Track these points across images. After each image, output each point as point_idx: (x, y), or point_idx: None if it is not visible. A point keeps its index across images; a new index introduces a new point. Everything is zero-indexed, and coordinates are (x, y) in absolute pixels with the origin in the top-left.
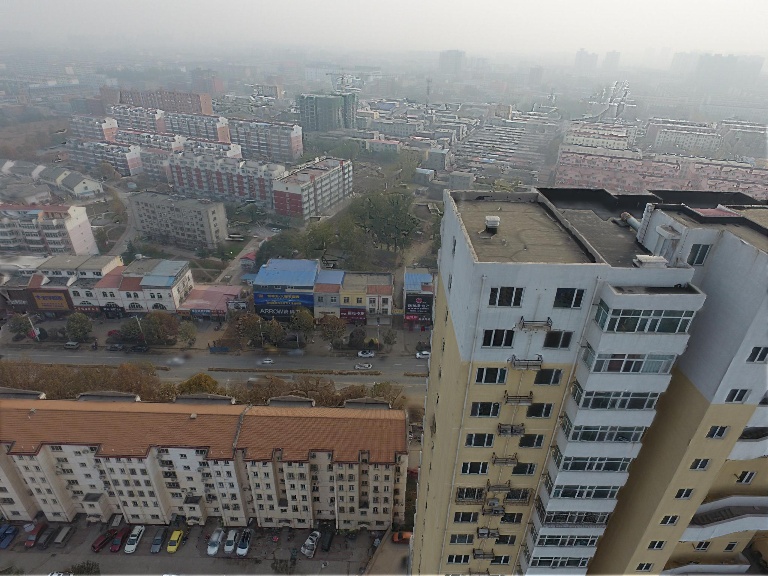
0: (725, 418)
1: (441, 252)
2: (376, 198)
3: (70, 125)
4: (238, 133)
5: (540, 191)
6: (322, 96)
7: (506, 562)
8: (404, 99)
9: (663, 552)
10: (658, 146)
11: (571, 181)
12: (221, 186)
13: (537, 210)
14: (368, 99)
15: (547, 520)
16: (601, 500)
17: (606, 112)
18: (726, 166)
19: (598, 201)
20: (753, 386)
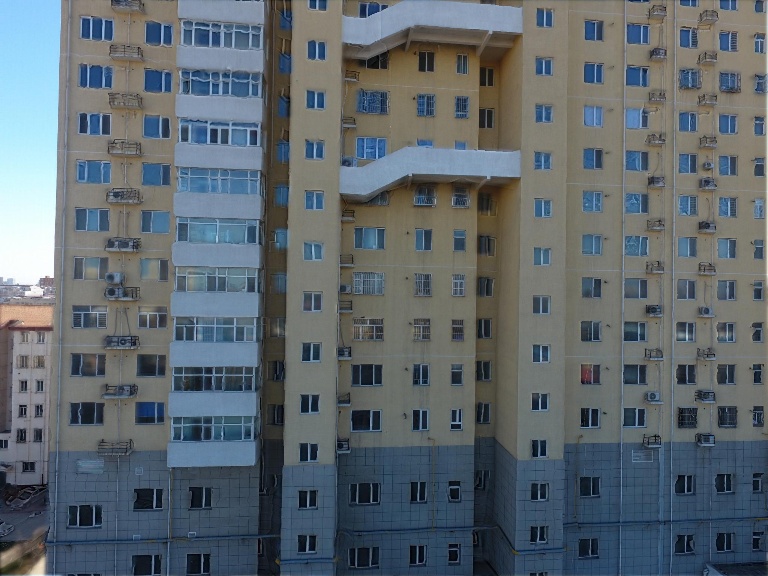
0: None
1: None
2: None
3: None
4: None
5: None
6: None
7: (169, 43)
8: None
9: None
10: None
11: None
12: None
13: None
14: None
15: None
16: None
17: None
18: None
19: None
20: None
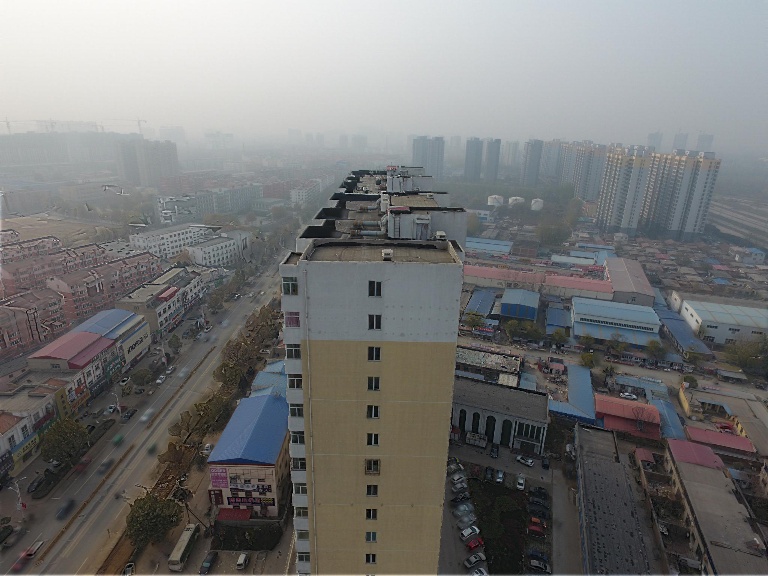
0: None
1: (308, 321)
2: None
3: None
4: None
5: None
6: None
7: None
8: None
9: None
10: None
11: None
12: None
13: (338, 248)
14: None
15: None
16: None
17: None
18: None
19: (310, 235)
20: None
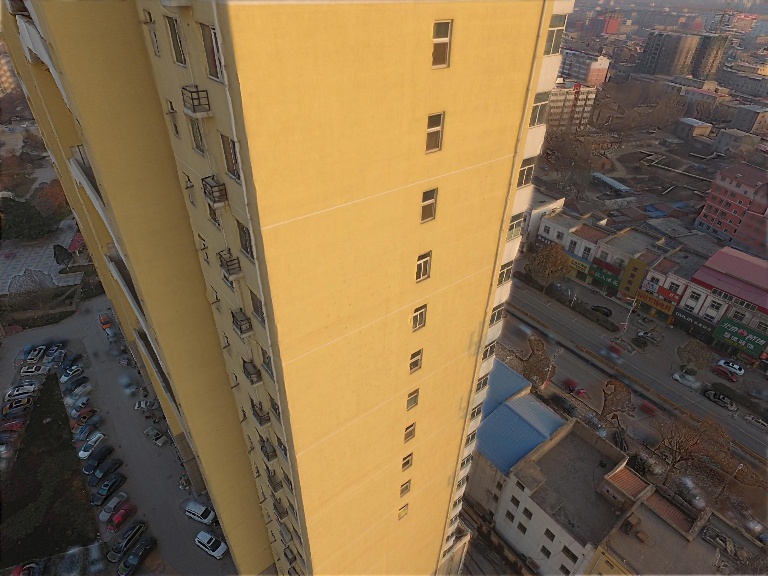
0: None
1: None
2: None
3: None
4: None
5: None
6: (676, 34)
7: None
8: None
9: None
10: None
11: None
12: None
13: None
14: None
15: None
16: None
17: None
18: None
19: None
20: None
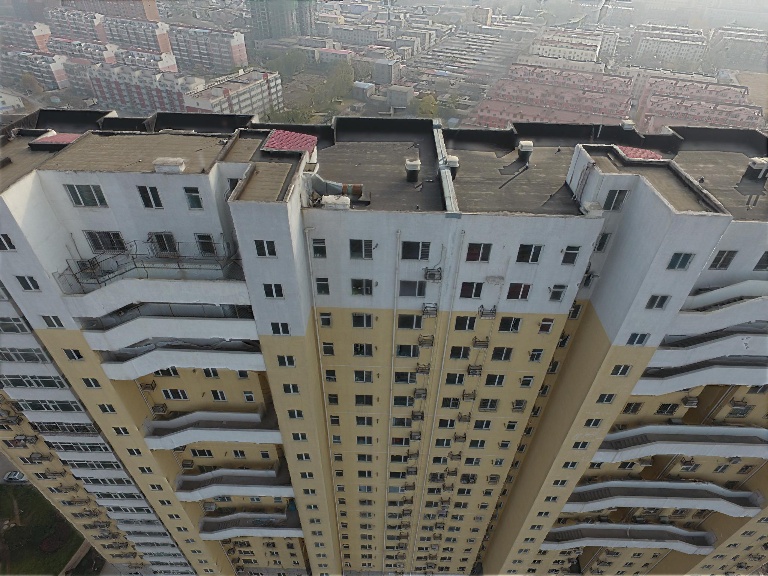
0: (63, 342)
1: None
2: (276, 115)
3: (1, 31)
4: (178, 41)
5: (48, 113)
6: None
7: None
8: (381, 1)
9: (145, 458)
10: (638, 57)
11: (509, 97)
12: (142, 101)
13: None
14: (342, 1)
15: (42, 429)
16: (71, 413)
17: (587, 17)
18: (682, 80)
19: None
20: (54, 313)
